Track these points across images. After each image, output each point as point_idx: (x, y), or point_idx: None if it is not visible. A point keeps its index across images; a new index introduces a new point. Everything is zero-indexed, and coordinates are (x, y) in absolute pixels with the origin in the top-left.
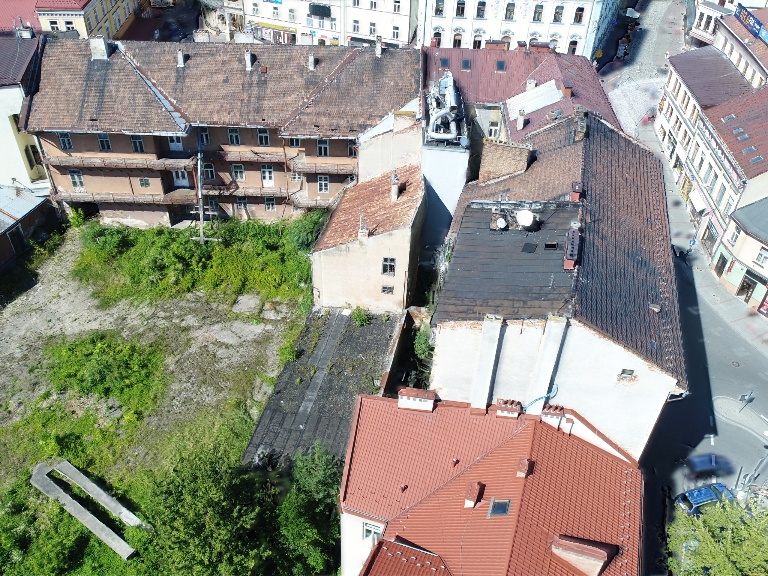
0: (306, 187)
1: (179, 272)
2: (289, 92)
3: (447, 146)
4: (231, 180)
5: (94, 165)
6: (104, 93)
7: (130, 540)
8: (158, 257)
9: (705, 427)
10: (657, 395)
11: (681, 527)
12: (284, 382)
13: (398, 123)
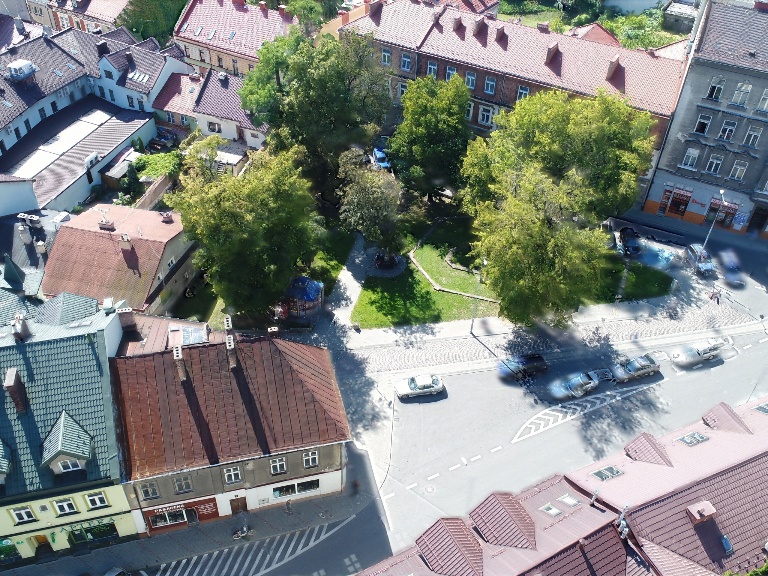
0: None
1: None
2: None
3: None
4: None
5: None
6: None
7: None
8: None
9: None
10: None
11: None
12: None
13: None
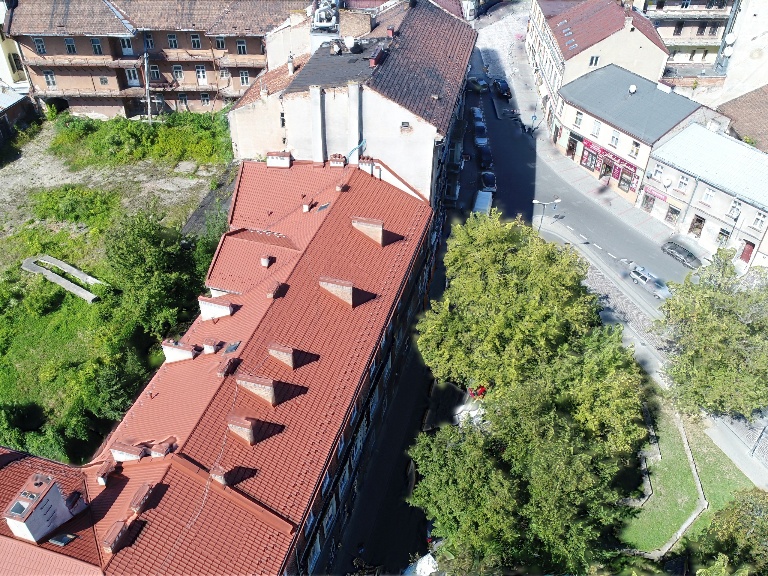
0: (231, 82)
1: (132, 146)
2: (213, 4)
3: (329, 33)
4: (173, 79)
5: (63, 65)
6: (69, 6)
7: (94, 291)
8: (116, 135)
9: None
10: (427, 142)
11: (454, 237)
12: (207, 201)
13: (293, 19)
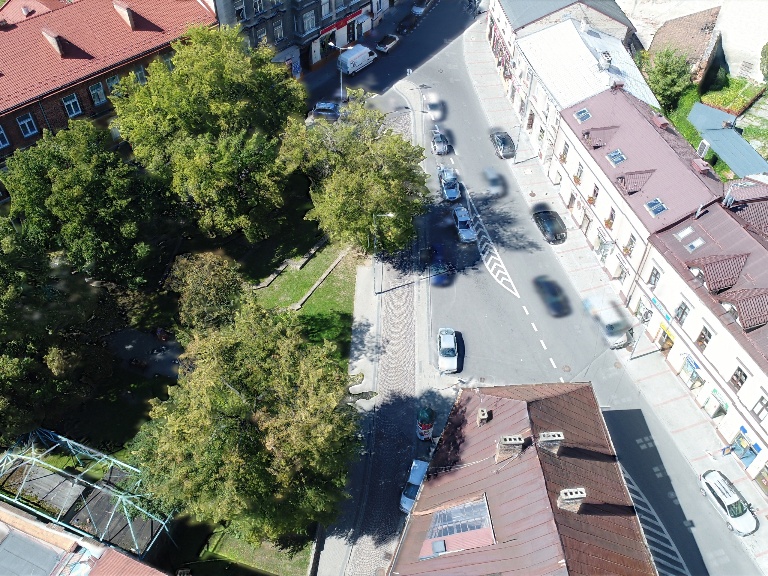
0: None
1: None
2: None
3: None
4: None
5: None
6: None
7: None
8: None
9: (378, 90)
10: None
11: None
12: None
13: None
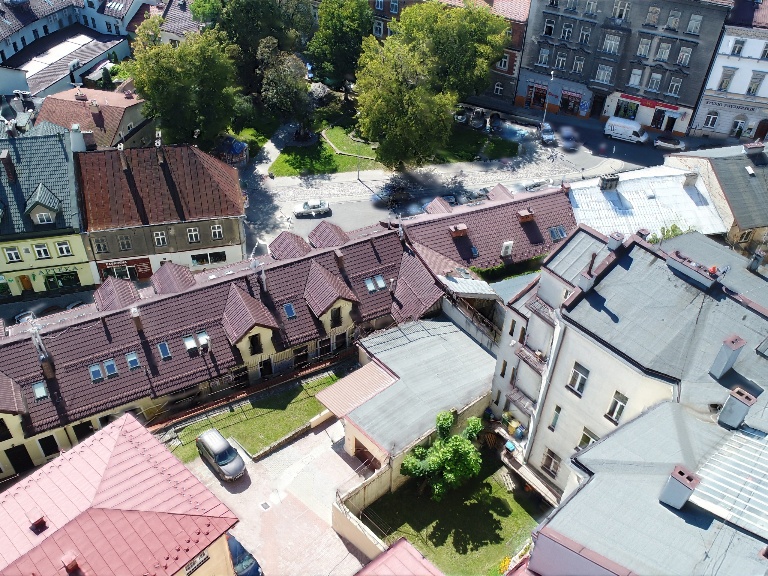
0: None
1: None
2: None
3: None
4: None
5: None
6: None
7: None
8: None
9: (598, 152)
10: None
11: None
12: None
13: None
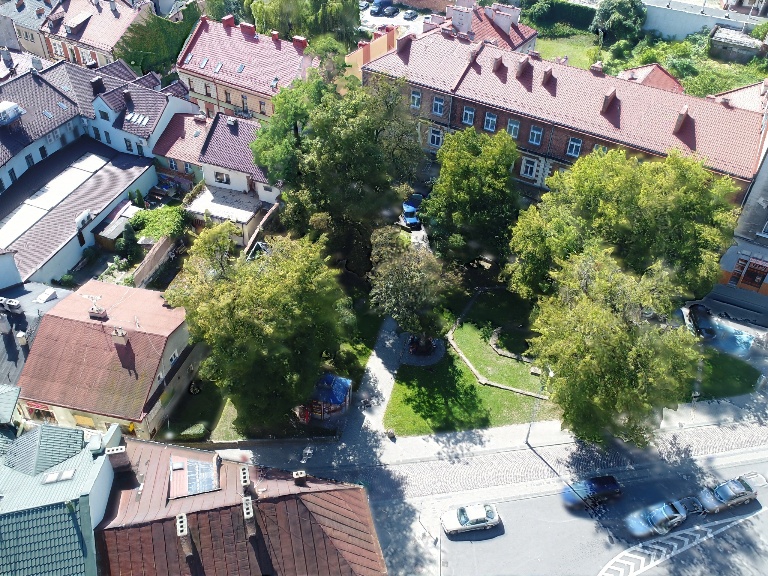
0: None
1: None
2: None
3: None
4: None
5: None
6: None
7: None
8: None
9: None
10: None
11: None
12: None
13: None
